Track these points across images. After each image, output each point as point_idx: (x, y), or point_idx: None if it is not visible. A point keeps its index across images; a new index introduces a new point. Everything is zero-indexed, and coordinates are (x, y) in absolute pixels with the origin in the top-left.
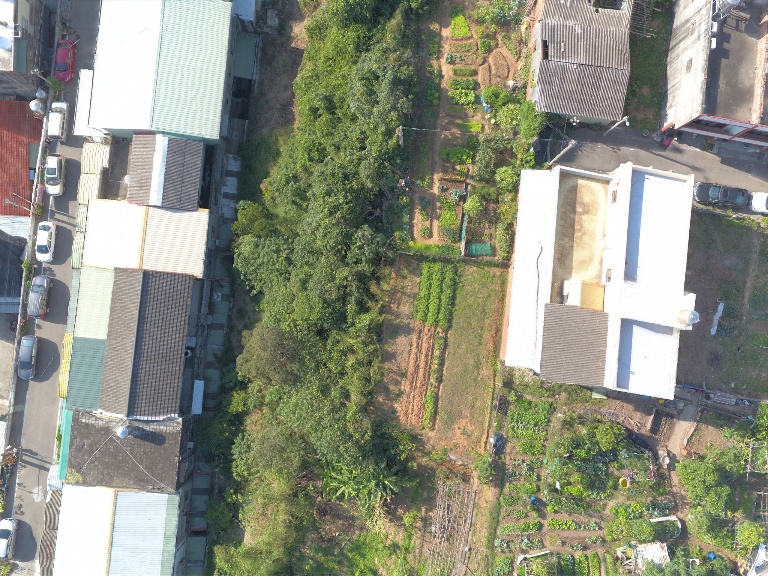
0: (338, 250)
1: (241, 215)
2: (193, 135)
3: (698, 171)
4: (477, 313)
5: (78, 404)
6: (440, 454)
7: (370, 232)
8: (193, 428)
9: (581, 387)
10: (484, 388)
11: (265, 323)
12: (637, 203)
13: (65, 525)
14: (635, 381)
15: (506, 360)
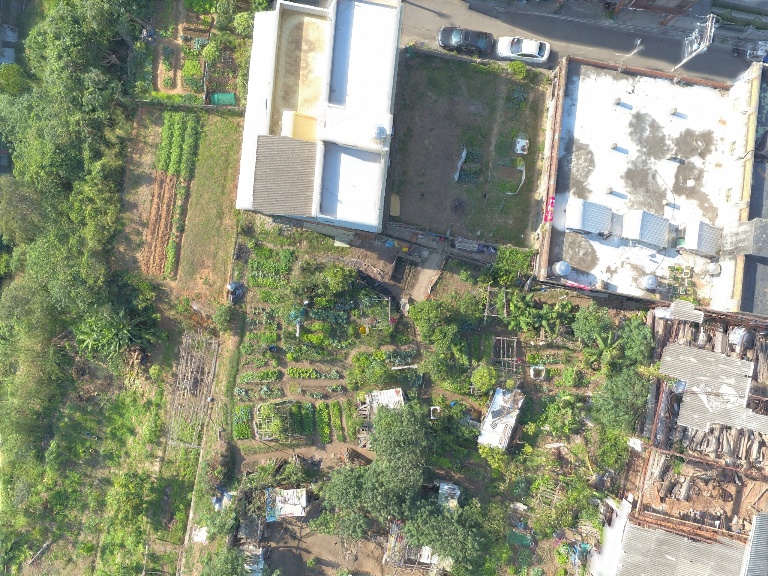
0: (75, 98)
1: None
2: None
3: (445, 17)
4: (220, 163)
5: None
6: (184, 306)
7: (102, 77)
8: None
9: (323, 235)
10: (227, 238)
11: None
12: (347, 30)
13: None
14: (343, 210)
15: (236, 203)
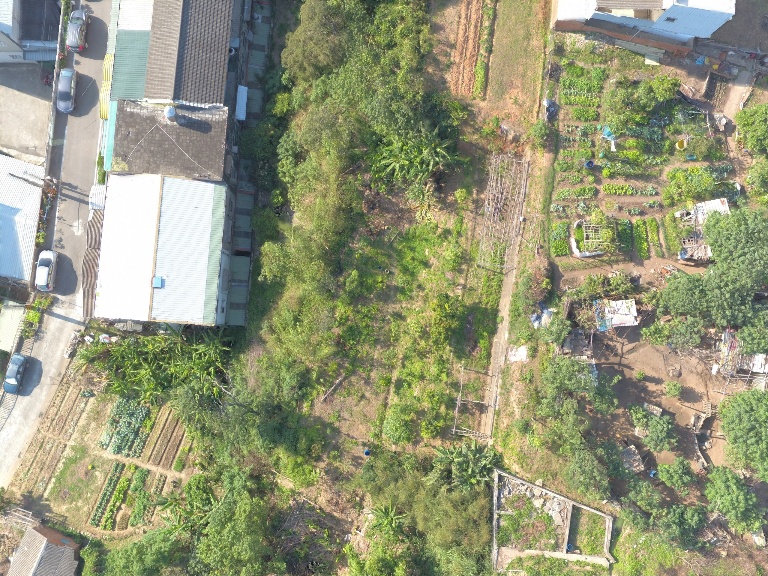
0: None
1: None
2: None
3: None
4: None
5: (123, 95)
6: (491, 127)
7: None
8: (236, 139)
9: (633, 53)
10: (535, 59)
11: None
12: None
13: (111, 215)
14: (694, 1)
15: (558, 14)
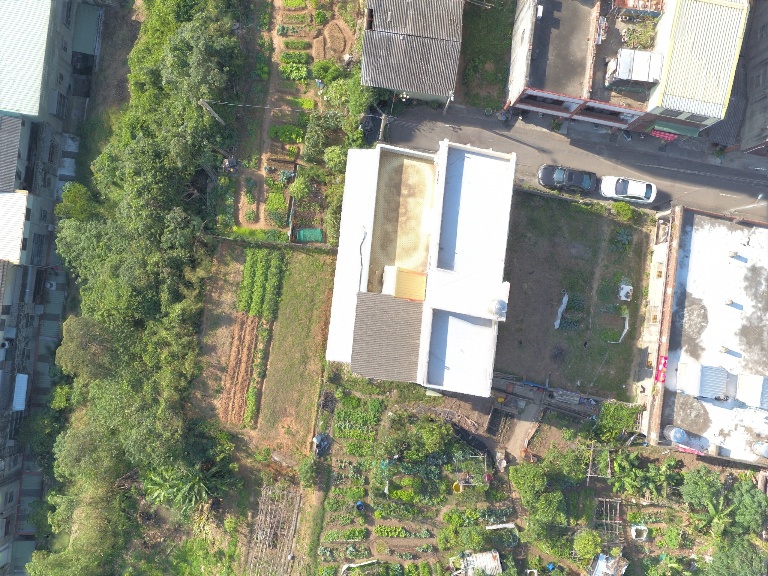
0: (152, 234)
1: (64, 197)
2: (8, 111)
3: (545, 153)
4: (305, 303)
5: None
6: (264, 455)
7: (183, 215)
8: (18, 425)
9: (414, 384)
10: (311, 384)
11: (82, 313)
12: (456, 184)
13: None
14: (450, 377)
15: (327, 354)
